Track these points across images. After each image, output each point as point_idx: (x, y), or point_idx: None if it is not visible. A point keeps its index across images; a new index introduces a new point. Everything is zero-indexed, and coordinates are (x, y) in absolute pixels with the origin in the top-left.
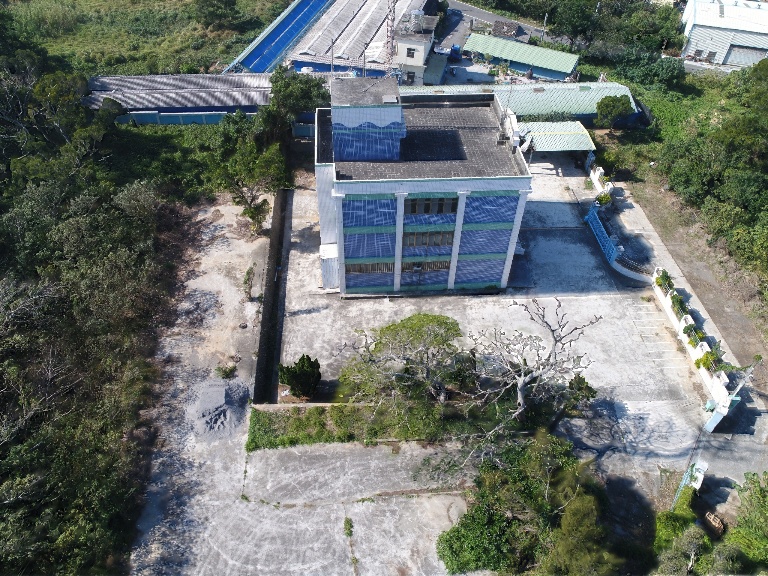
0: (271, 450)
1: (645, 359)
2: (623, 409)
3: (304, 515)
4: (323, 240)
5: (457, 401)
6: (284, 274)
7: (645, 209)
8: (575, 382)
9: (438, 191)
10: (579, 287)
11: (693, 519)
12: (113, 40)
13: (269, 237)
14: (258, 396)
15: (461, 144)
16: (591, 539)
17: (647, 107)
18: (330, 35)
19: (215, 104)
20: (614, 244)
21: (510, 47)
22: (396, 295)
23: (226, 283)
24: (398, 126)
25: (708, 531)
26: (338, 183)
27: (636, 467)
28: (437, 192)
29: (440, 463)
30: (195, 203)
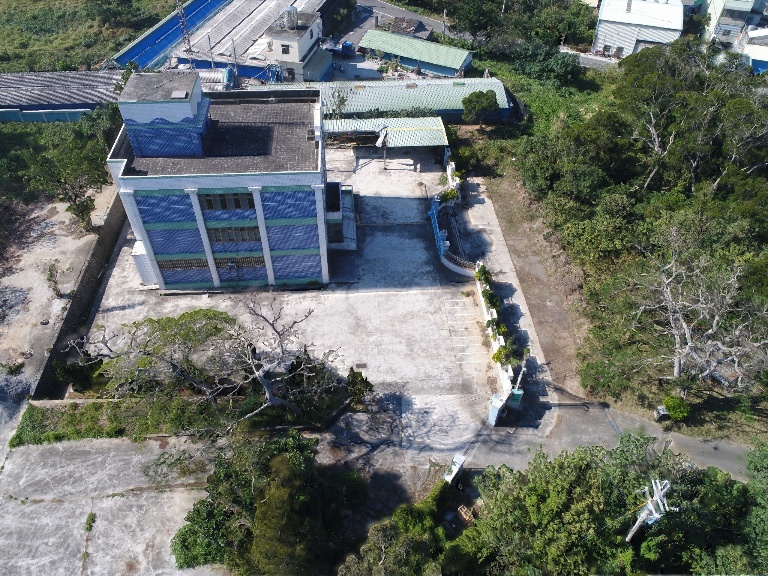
0: (35, 446)
1: (447, 353)
2: (410, 403)
3: (49, 510)
4: (138, 236)
5: (242, 396)
6: (110, 271)
7: (496, 204)
8: (350, 376)
9: (228, 186)
10: (402, 282)
11: (430, 512)
12: (4, 38)
13: (98, 234)
14: (43, 392)
15: (271, 140)
16: (297, 532)
17: (522, 102)
18: (219, 32)
19: (78, 101)
20: (444, 239)
21: (404, 43)
22: (216, 291)
23: (40, 280)
24: (191, 122)
25: (458, 524)
26: (123, 179)
27: (406, 461)
28: (228, 187)
29: (168, 457)
30: (33, 200)
